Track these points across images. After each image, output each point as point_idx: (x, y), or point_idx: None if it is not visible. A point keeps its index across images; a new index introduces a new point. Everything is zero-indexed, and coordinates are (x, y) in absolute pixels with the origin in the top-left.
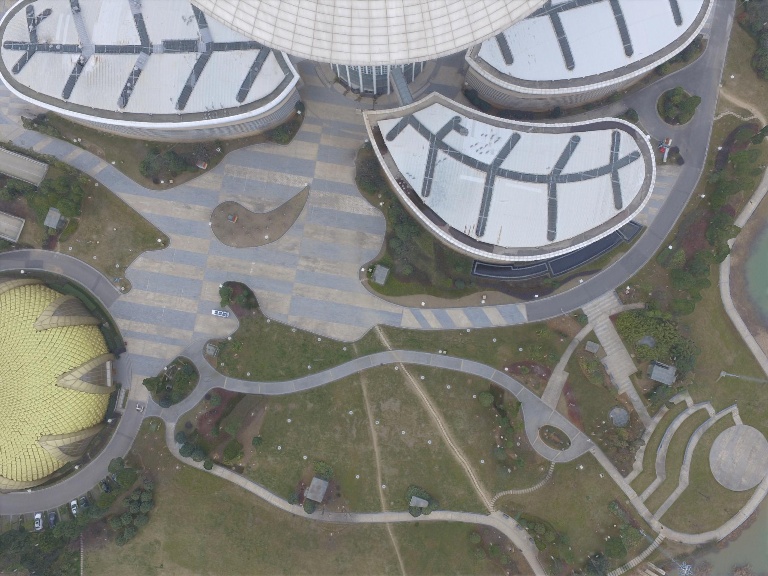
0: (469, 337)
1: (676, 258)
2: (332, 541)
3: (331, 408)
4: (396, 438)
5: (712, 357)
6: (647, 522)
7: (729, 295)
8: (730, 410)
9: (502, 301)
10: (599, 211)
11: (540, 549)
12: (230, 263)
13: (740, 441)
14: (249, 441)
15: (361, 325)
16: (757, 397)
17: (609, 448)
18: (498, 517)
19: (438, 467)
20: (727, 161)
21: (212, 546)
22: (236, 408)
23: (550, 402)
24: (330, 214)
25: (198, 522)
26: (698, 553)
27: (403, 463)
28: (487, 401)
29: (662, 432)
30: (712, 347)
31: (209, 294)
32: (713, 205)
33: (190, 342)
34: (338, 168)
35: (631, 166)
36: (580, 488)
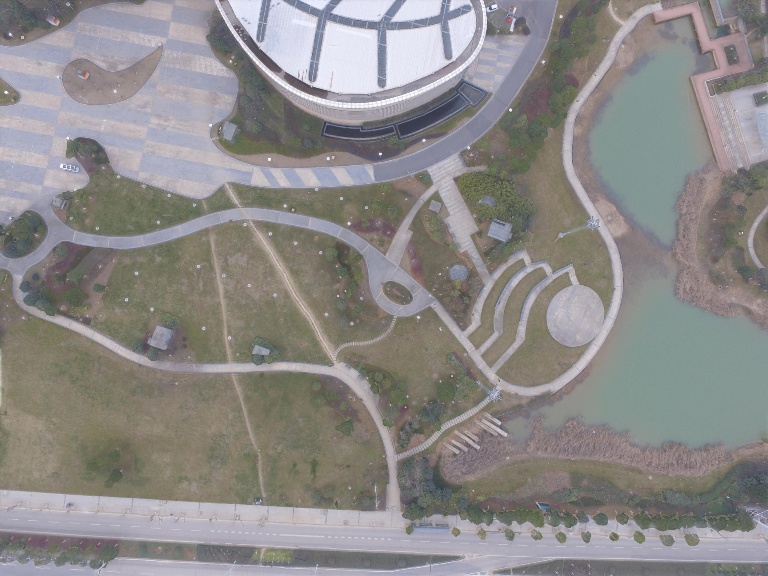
0: (317, 195)
1: (519, 123)
2: (177, 390)
3: (179, 262)
4: (242, 291)
5: (551, 219)
6: (484, 374)
7: (571, 163)
8: (566, 270)
9: (350, 162)
10: (429, 60)
11: (374, 392)
12: (81, 120)
13: (576, 300)
14: (96, 293)
15: (211, 183)
16: (593, 258)
17: (444, 298)
18: (341, 368)
19: (283, 319)
20: (570, 32)
21: (56, 393)
22: (84, 261)
23: (394, 259)
24: (183, 74)
25: (42, 370)
26: (532, 403)
27: (249, 315)
28: (328, 253)
29: (501, 289)
30: (551, 210)
31: (59, 150)
32: (552, 70)
33: (39, 196)
34: (192, 29)
35: (462, 18)
36: (420, 340)
